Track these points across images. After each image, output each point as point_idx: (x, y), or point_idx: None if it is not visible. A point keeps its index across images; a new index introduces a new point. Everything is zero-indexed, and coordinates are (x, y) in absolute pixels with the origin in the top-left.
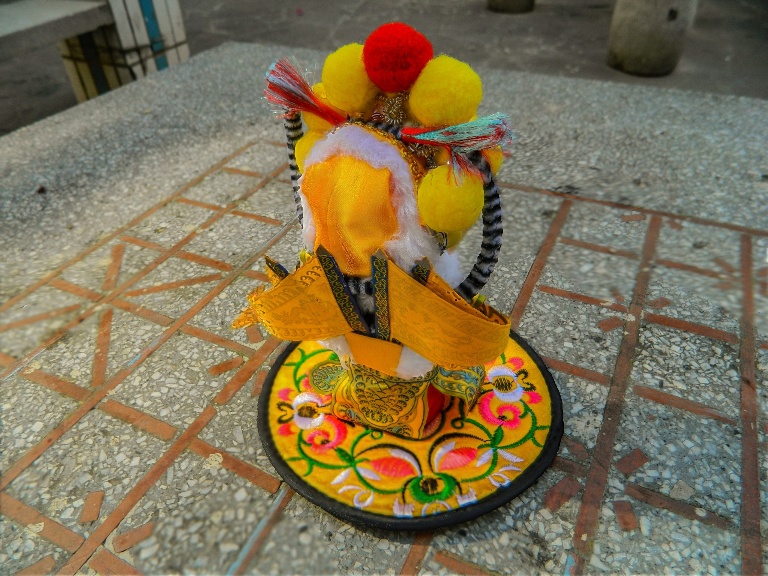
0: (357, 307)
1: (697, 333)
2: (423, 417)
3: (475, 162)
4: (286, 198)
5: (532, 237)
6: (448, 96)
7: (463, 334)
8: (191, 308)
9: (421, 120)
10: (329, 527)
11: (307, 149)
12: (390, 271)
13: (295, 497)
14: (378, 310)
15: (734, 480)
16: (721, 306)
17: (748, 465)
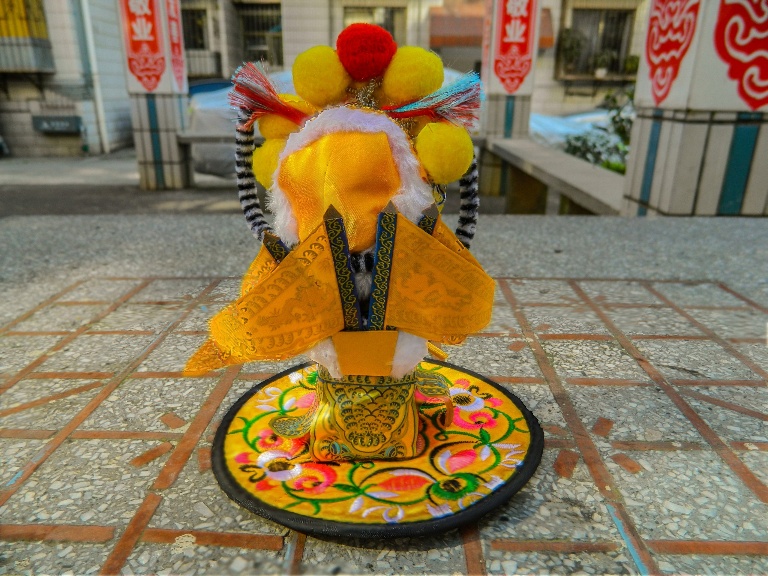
0: (355, 288)
1: (584, 339)
2: (414, 428)
3: None
4: (148, 314)
5: None
6: (425, 69)
7: (465, 291)
8: (75, 416)
9: (398, 96)
10: (365, 559)
11: (272, 152)
12: (398, 227)
13: (308, 545)
14: (375, 289)
15: (681, 418)
16: (587, 321)
17: (682, 406)
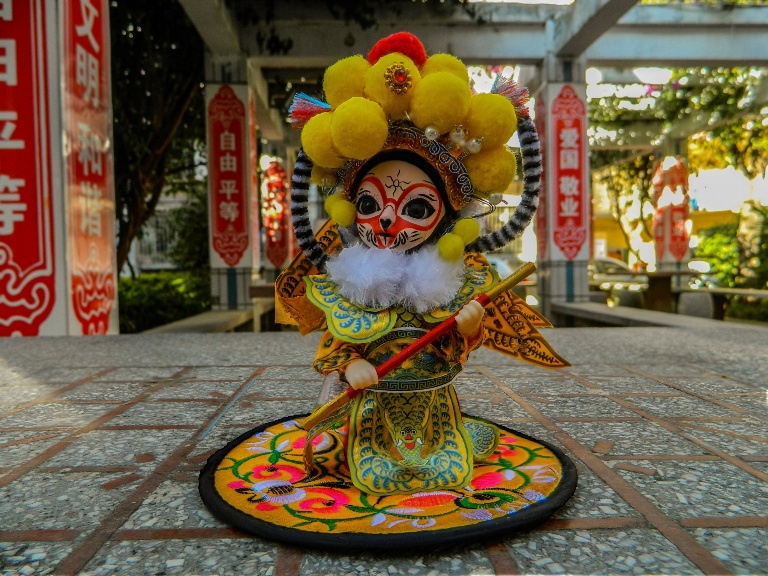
0: None
1: None
2: None
3: None
4: None
5: None
6: None
7: None
8: (763, 472)
9: None
10: None
11: None
12: None
13: None
14: None
15: (3, 491)
16: None
17: None
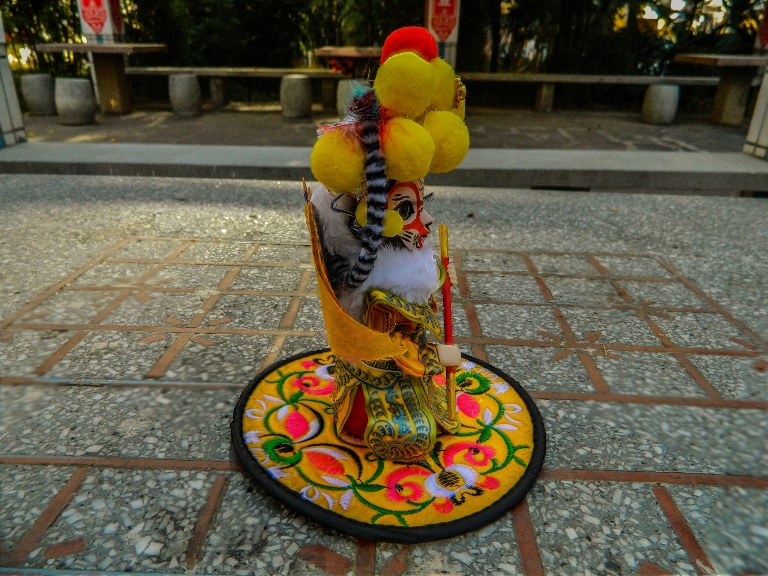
0: None
1: None
2: (346, 415)
3: (363, 134)
4: (591, 292)
5: (763, 463)
6: None
7: None
8: None
9: None
10: None
11: None
12: None
13: None
14: None
15: None
16: None
17: None
